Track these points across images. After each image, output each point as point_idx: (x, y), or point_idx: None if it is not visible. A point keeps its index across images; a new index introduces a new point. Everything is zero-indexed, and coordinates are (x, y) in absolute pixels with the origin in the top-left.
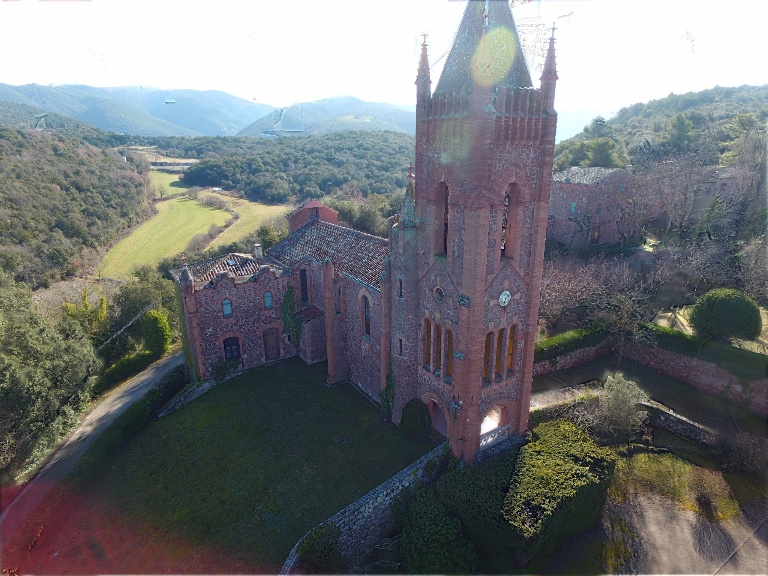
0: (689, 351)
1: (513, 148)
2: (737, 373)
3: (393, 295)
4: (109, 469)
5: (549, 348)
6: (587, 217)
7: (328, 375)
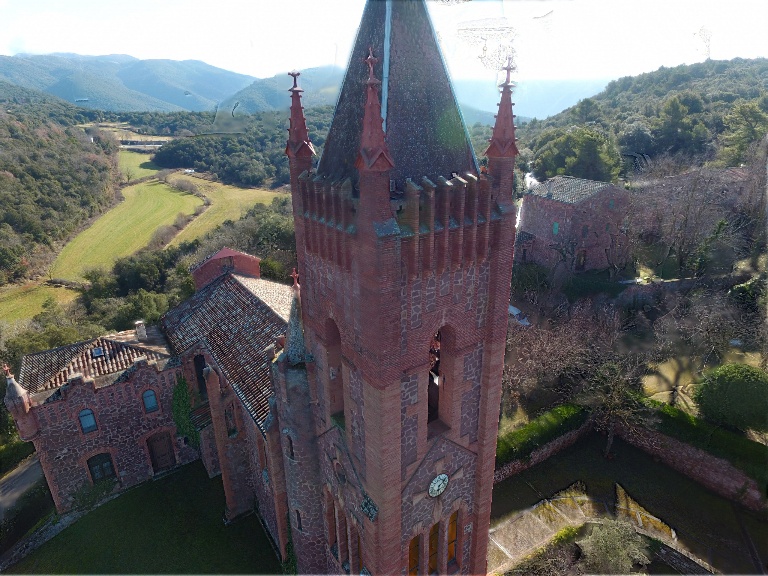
0: (694, 440)
1: (441, 275)
2: (755, 477)
3: (283, 451)
4: None
5: (520, 446)
6: (571, 244)
7: (226, 507)
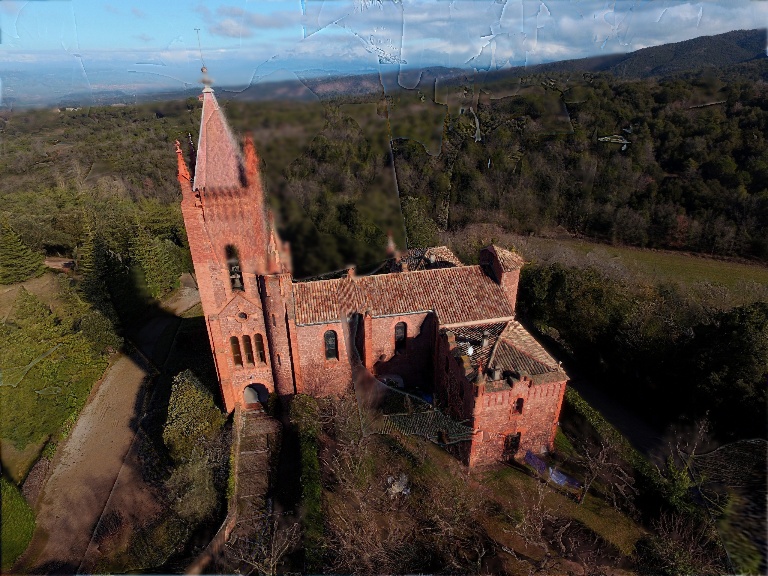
0: None
1: None
2: None
3: None
4: None
5: None
6: None
7: None
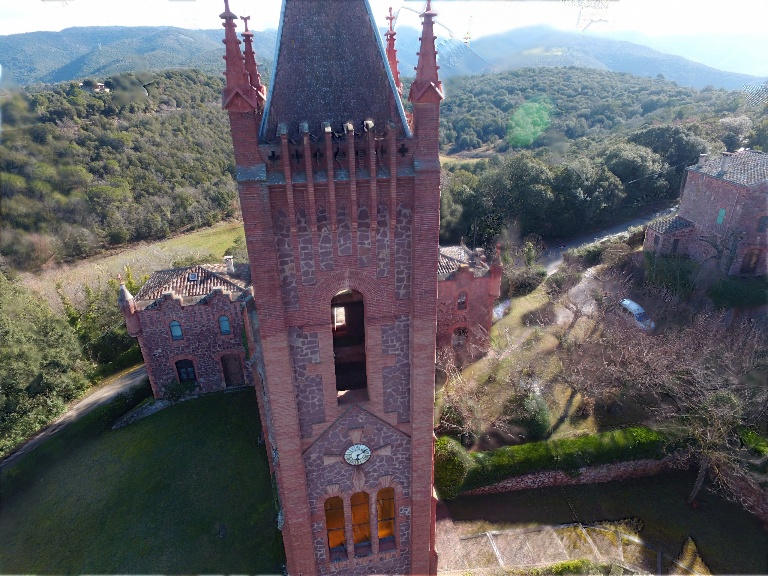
0: None
1: (338, 233)
2: None
3: None
4: (38, 481)
5: (564, 456)
6: (734, 237)
7: (261, 429)
